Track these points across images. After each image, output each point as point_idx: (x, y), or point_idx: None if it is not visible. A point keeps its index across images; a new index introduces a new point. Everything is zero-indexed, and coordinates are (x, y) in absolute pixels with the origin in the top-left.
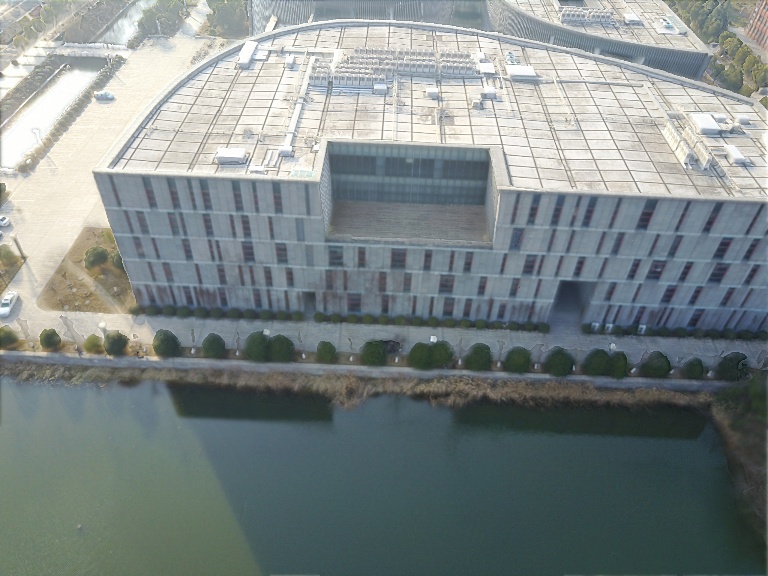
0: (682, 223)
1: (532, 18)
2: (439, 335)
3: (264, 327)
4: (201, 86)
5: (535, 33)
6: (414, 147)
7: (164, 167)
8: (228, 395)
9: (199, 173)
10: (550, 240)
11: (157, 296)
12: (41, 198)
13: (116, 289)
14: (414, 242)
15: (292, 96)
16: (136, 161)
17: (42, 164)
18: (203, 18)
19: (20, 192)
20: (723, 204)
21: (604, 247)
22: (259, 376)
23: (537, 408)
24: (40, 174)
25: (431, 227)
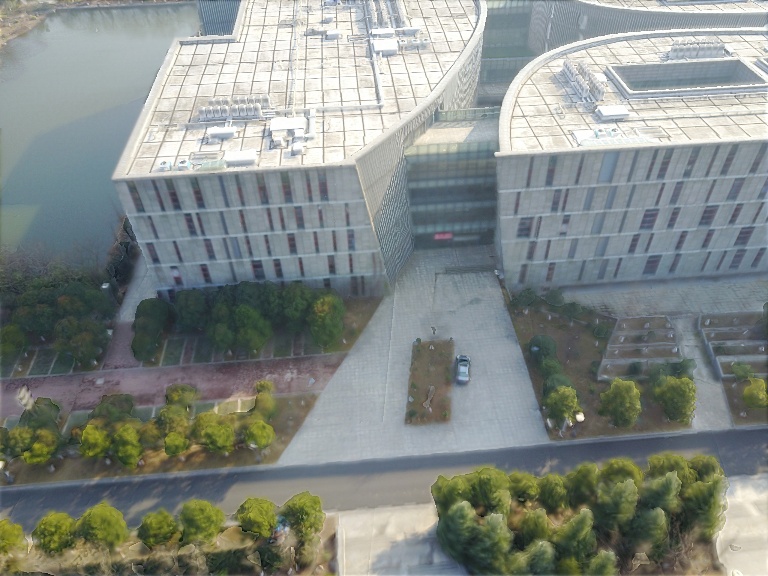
0: None
1: None
2: None
3: None
4: None
5: None
6: None
7: None
8: None
9: None
10: None
11: None
12: None
13: None
14: None
15: None
16: None
17: None
18: None
19: None
20: None
21: None
22: None
23: None
24: None
25: None
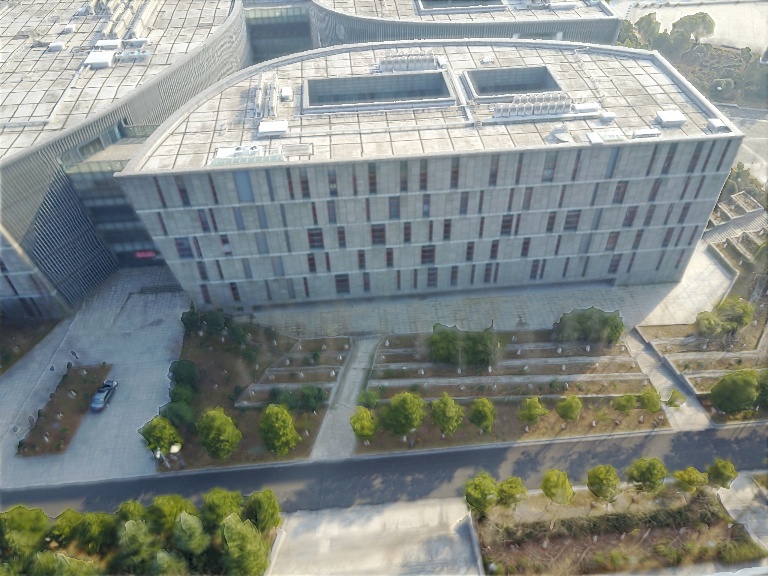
0: None
1: None
2: None
3: None
4: None
5: None
6: None
7: None
8: None
9: None
10: None
11: None
12: None
13: None
14: None
15: None
16: None
17: None
18: None
19: None
20: None
21: None
22: None
23: None
24: None
25: None
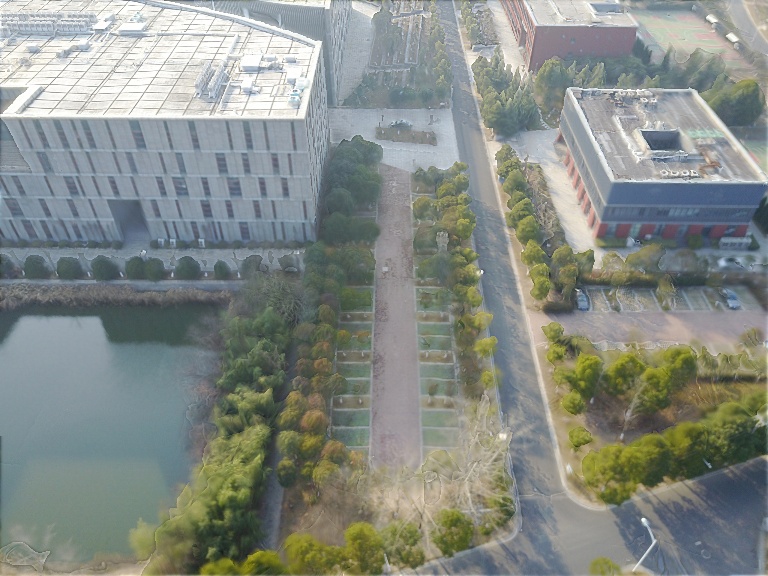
0: (172, 141)
1: None
2: (24, 254)
3: None
4: None
5: None
6: None
7: None
8: None
9: None
10: (73, 162)
11: None
12: None
13: None
14: None
15: None
16: None
17: None
18: None
19: None
20: (194, 122)
21: (123, 166)
22: None
23: (79, 308)
24: None
25: None
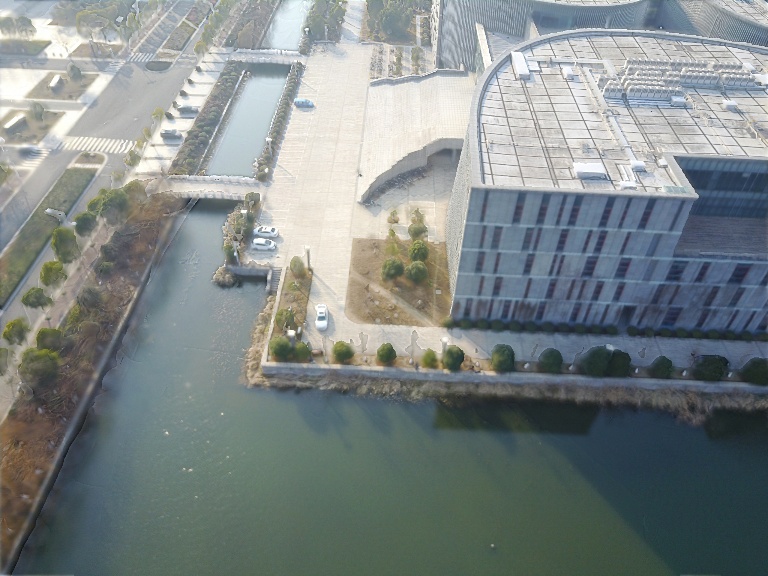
0: None
1: (765, 27)
2: (755, 349)
3: (581, 341)
4: (500, 98)
5: (766, 42)
6: (757, 162)
7: (531, 182)
8: (571, 410)
9: (577, 189)
10: None
11: (474, 310)
12: (294, 208)
13: (420, 302)
14: (762, 257)
15: (600, 109)
16: (500, 176)
17: (277, 173)
18: (359, 23)
19: (270, 202)
20: None
21: None
22: (595, 391)
23: None
24: (280, 183)
25: (764, 241)
